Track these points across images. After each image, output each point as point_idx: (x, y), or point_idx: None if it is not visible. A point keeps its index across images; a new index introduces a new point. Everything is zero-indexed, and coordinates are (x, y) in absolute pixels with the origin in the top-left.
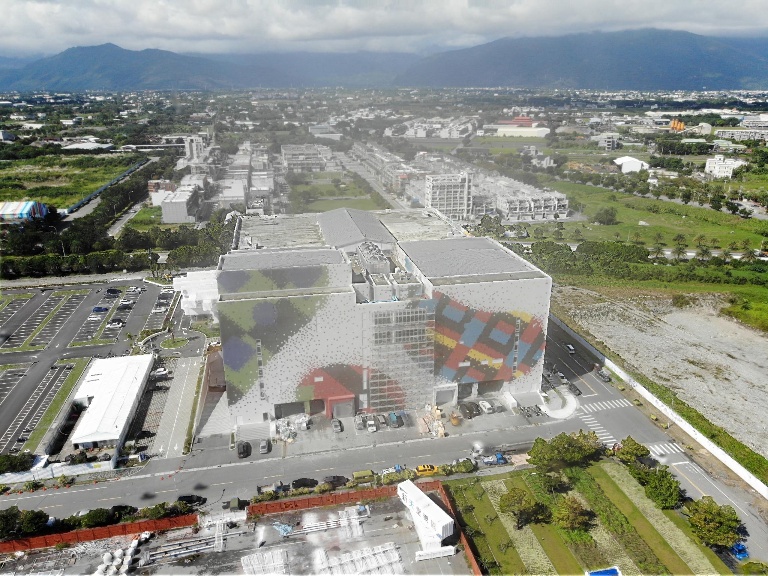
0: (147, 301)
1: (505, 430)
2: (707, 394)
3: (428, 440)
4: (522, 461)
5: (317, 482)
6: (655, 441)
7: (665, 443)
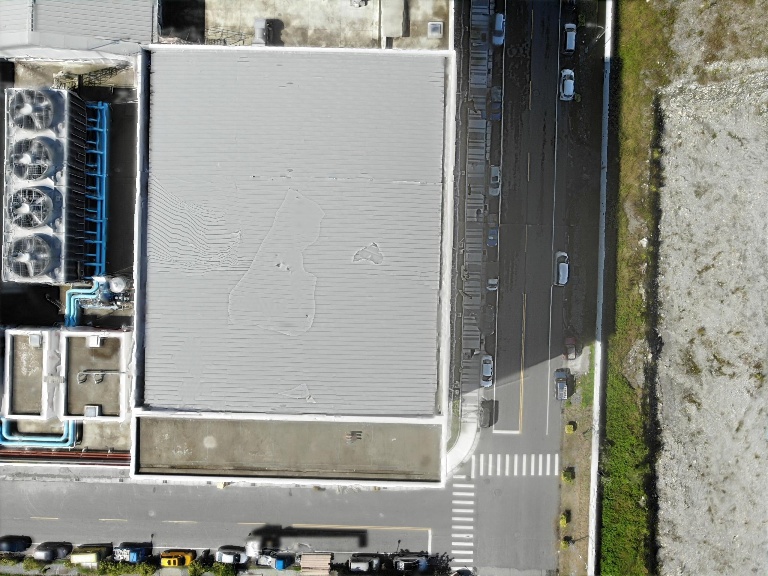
0: None
1: (323, 490)
2: (726, 432)
3: (200, 487)
4: (311, 572)
5: (30, 542)
6: (527, 568)
7: (539, 575)
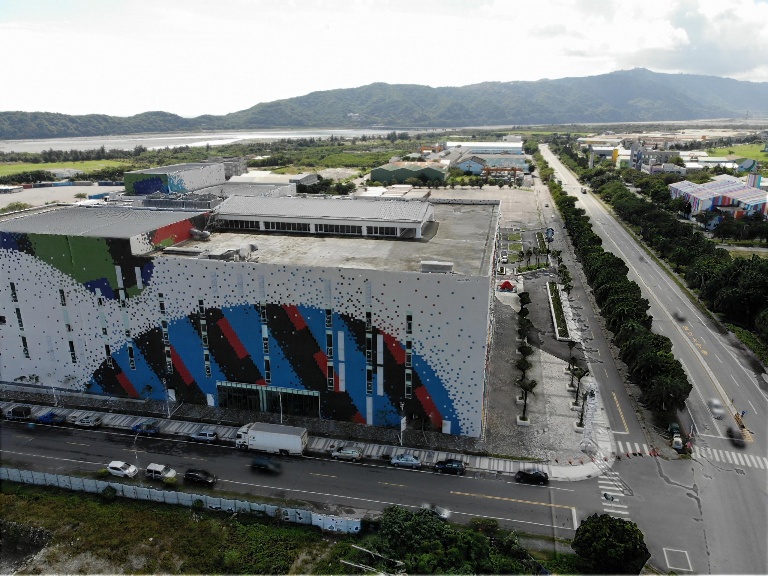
0: None
1: None
2: None
3: None
4: None
5: None
6: None
7: None
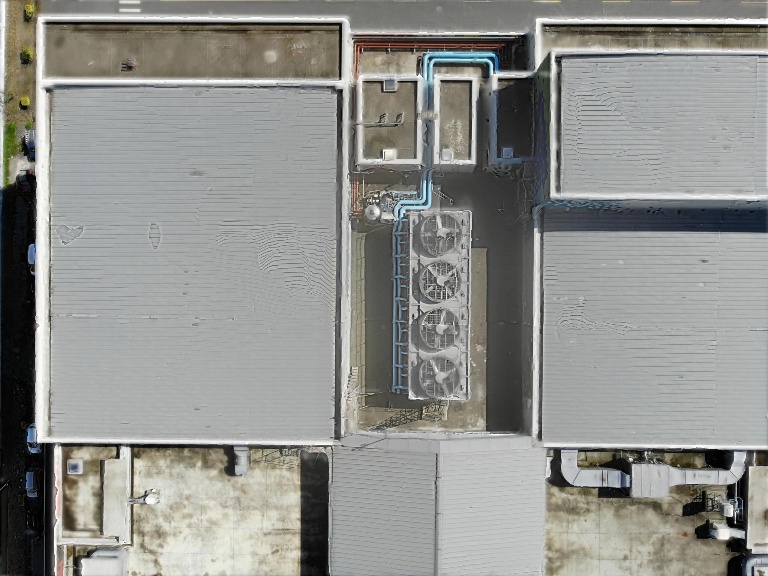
0: None
1: None
2: None
3: None
4: None
5: None
6: None
7: None
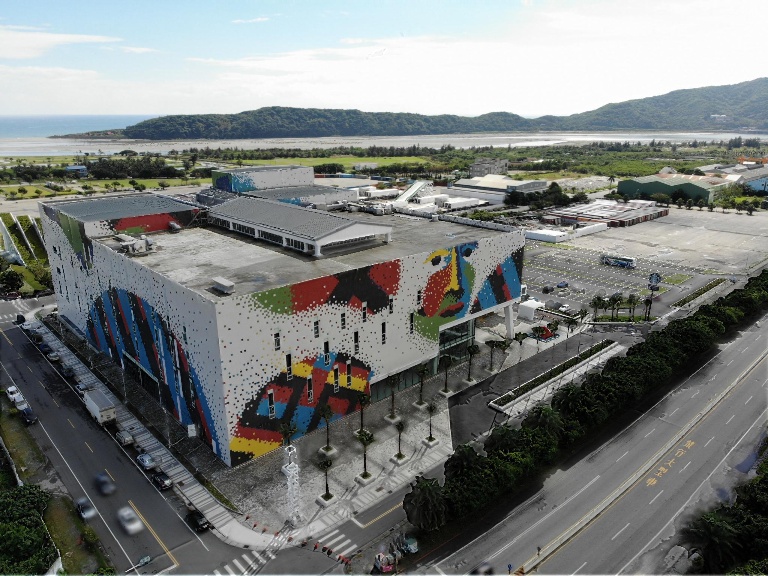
0: (557, 300)
1: None
2: None
3: None
4: None
5: None
6: None
7: None
